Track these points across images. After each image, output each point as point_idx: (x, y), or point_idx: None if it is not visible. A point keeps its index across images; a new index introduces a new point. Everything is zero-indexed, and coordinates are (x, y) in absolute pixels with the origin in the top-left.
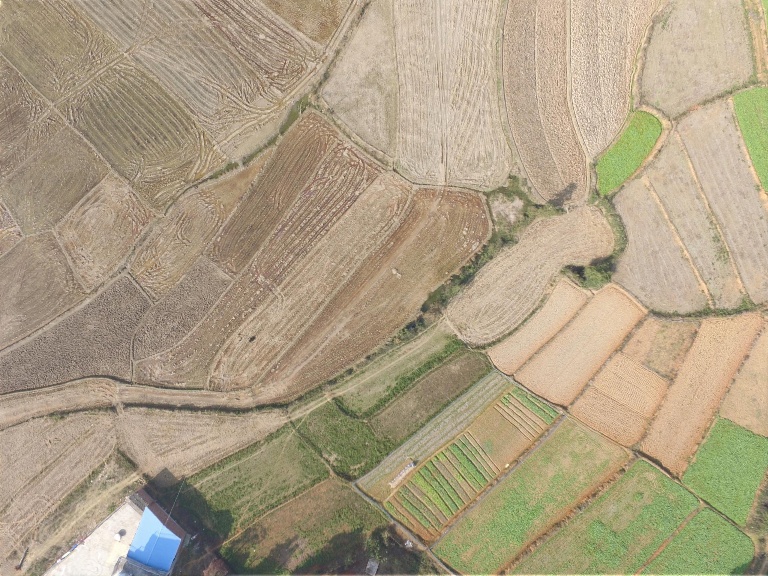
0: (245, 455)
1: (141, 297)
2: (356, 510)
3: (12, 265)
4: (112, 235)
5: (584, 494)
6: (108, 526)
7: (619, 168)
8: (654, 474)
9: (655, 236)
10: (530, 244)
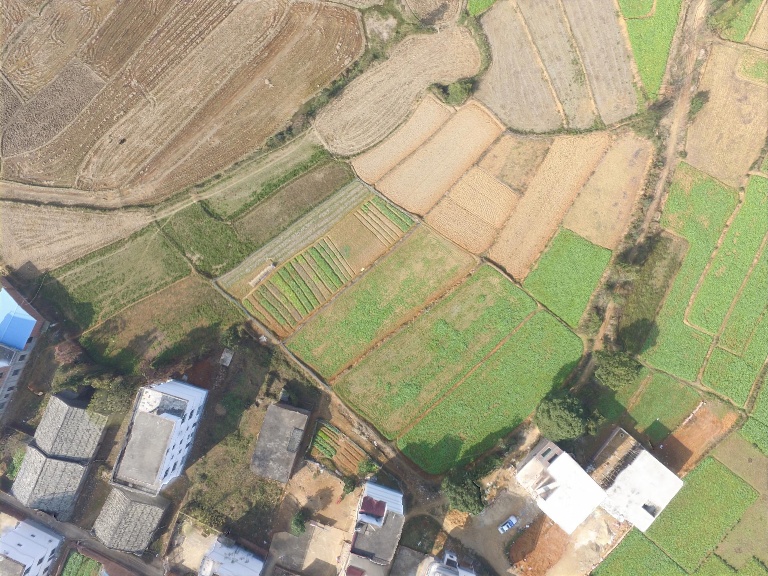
0: (109, 251)
1: (12, 95)
2: (215, 306)
3: None
4: None
5: (432, 297)
6: None
7: None
8: (498, 278)
9: (518, 57)
10: (400, 61)
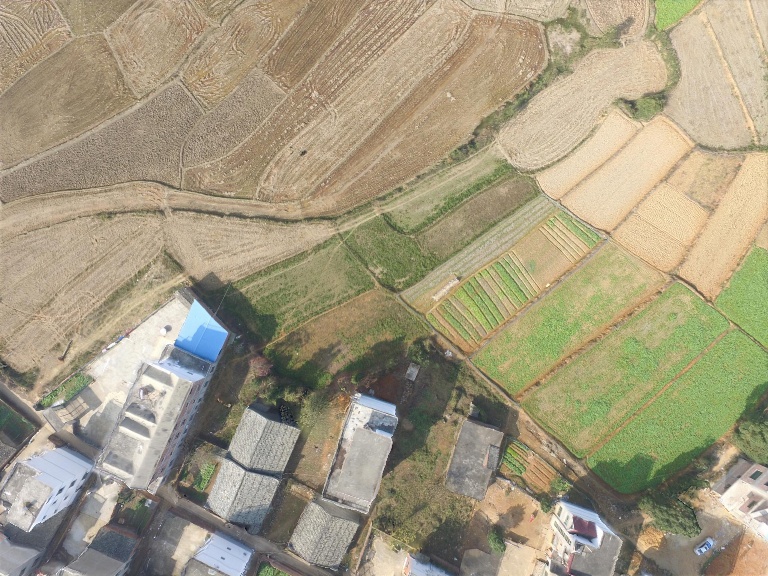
0: (292, 263)
1: (193, 105)
2: (399, 320)
3: (61, 65)
4: (165, 42)
5: (620, 314)
6: (154, 322)
7: (678, 4)
8: (689, 296)
9: (708, 72)
10: (585, 75)
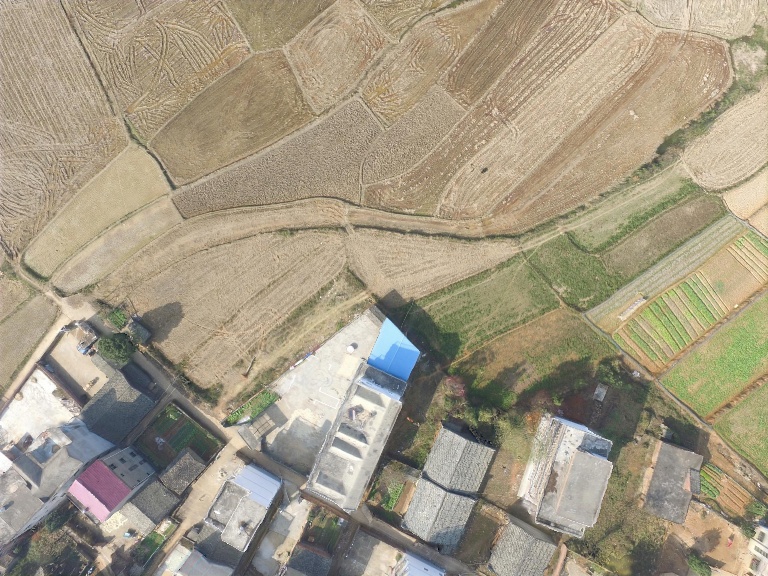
0: (475, 281)
1: (372, 122)
2: (585, 340)
3: (240, 81)
4: (344, 58)
5: None
6: (339, 339)
7: None
8: None
9: None
10: None
